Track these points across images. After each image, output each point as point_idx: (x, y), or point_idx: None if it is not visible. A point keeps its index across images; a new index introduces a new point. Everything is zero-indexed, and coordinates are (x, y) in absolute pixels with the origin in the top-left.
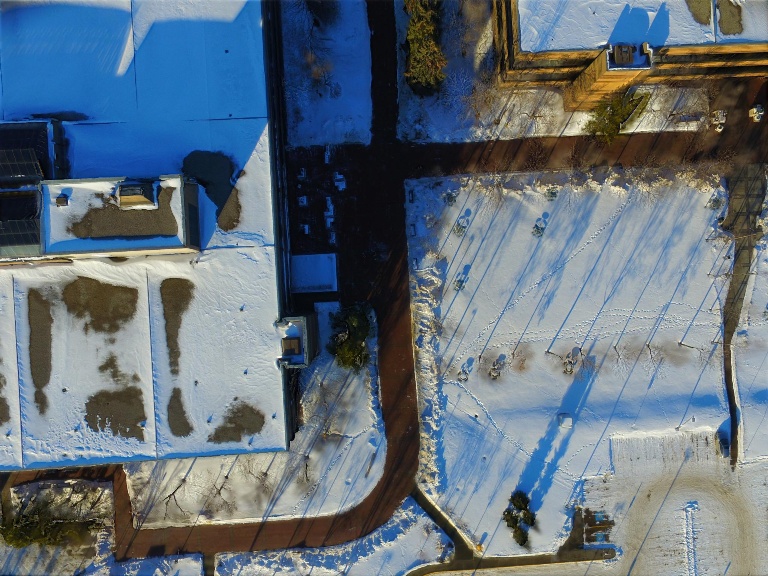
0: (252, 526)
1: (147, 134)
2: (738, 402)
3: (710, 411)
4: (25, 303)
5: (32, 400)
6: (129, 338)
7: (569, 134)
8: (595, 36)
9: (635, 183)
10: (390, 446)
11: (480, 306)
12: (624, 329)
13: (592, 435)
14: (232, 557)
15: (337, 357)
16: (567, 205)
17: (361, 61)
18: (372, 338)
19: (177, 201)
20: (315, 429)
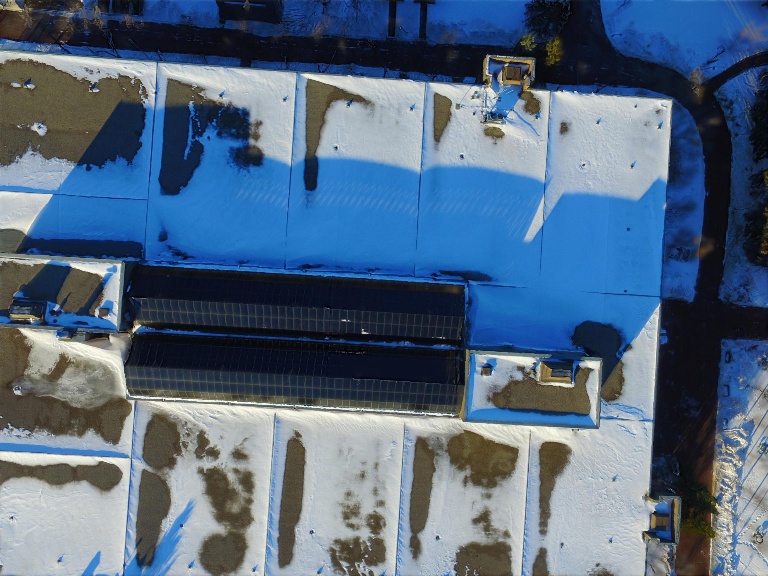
0: None
1: (546, 301)
2: None
3: None
4: (412, 450)
5: (407, 544)
6: (505, 495)
7: None
8: None
9: None
10: None
11: None
12: None
13: None
14: None
15: None
16: None
17: (694, 221)
18: None
19: (594, 382)
20: None
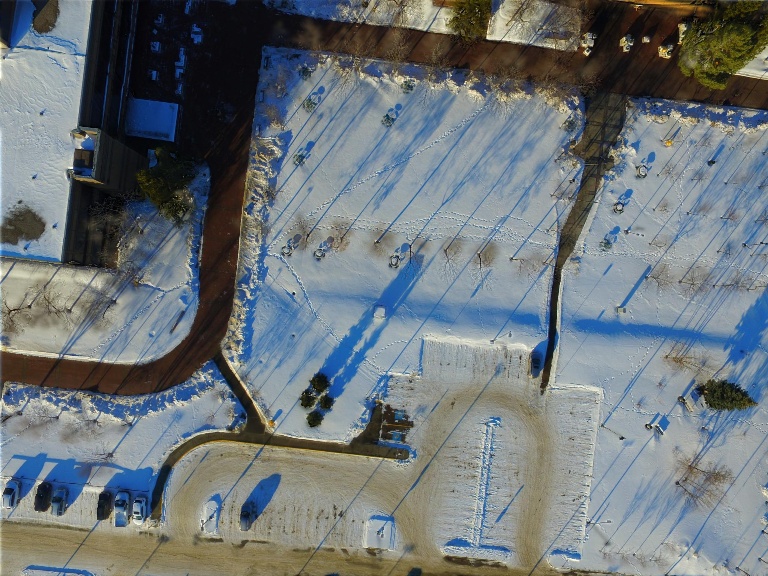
0: (47, 361)
1: None
2: (559, 326)
3: (528, 329)
4: None
5: None
6: None
7: (436, 31)
8: None
9: (494, 91)
10: (201, 307)
11: (317, 185)
12: (458, 234)
13: (405, 332)
14: (22, 388)
15: (161, 206)
16: (422, 101)
17: None
18: (202, 196)
19: None
20: (127, 275)
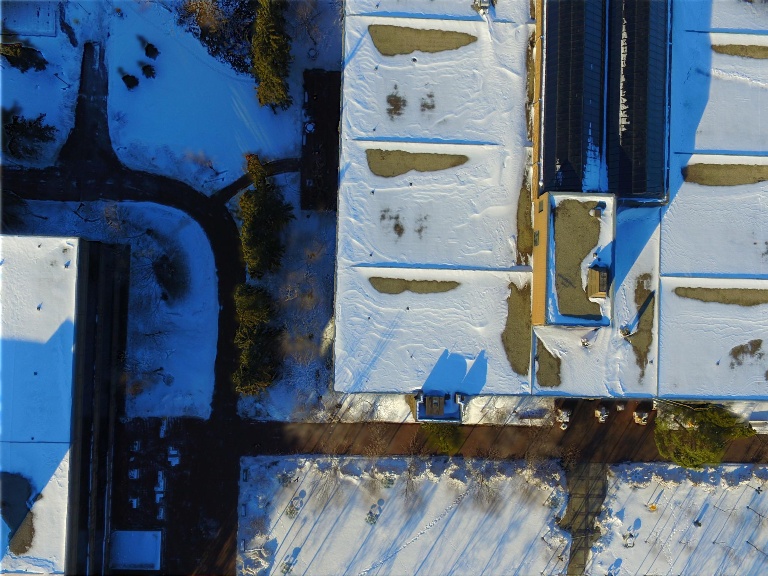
0: None
1: None
2: None
3: None
4: None
5: None
6: None
7: (412, 421)
8: (410, 380)
9: (474, 475)
10: None
11: None
12: None
13: None
14: None
15: None
16: (404, 493)
17: (207, 336)
18: None
19: None
20: None
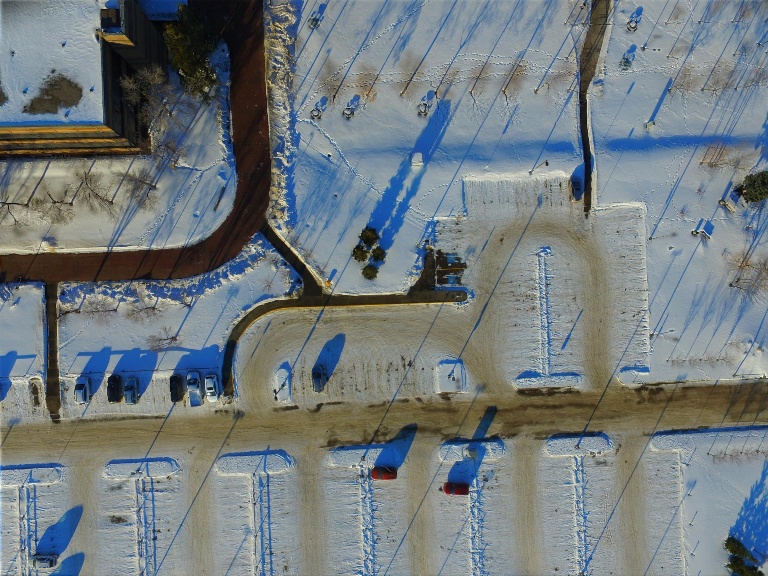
0: (97, 256)
1: None
2: (592, 149)
3: (563, 156)
4: None
5: None
6: None
7: None
8: None
9: None
10: (241, 181)
11: (335, 45)
12: (480, 74)
13: (445, 176)
14: (76, 286)
15: (186, 85)
16: None
17: None
18: (224, 72)
19: None
20: (163, 158)
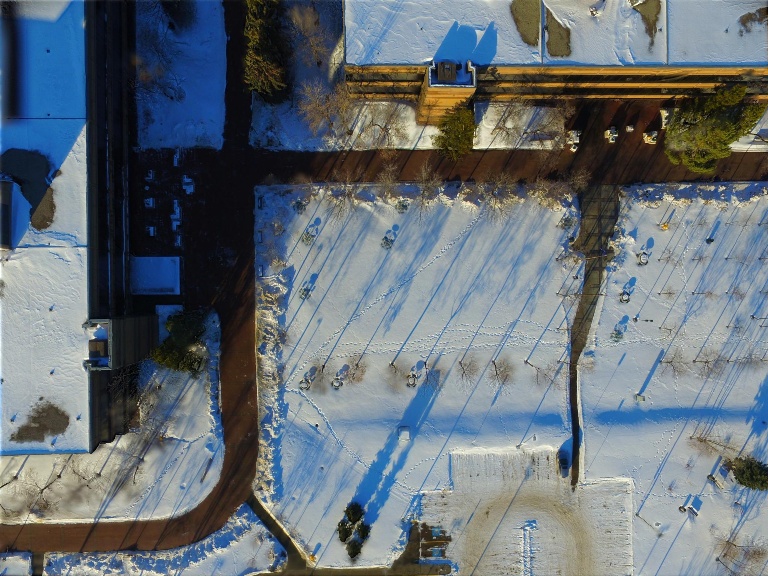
0: (84, 527)
1: None
2: (581, 422)
3: (552, 430)
4: None
5: None
6: None
7: (423, 148)
8: (421, 52)
9: (487, 199)
10: (228, 452)
11: (325, 315)
12: (470, 345)
13: (431, 449)
14: (62, 557)
15: None
16: (418, 218)
17: (215, 66)
18: (214, 343)
19: None
20: (151, 432)
